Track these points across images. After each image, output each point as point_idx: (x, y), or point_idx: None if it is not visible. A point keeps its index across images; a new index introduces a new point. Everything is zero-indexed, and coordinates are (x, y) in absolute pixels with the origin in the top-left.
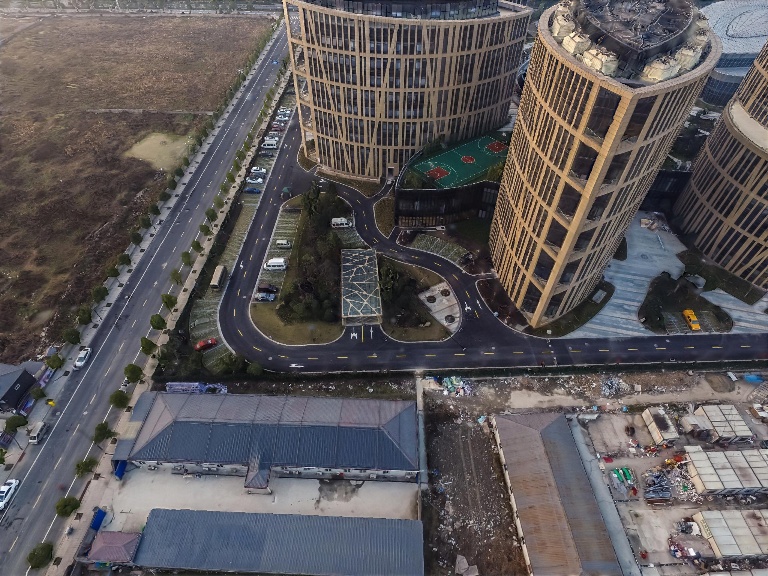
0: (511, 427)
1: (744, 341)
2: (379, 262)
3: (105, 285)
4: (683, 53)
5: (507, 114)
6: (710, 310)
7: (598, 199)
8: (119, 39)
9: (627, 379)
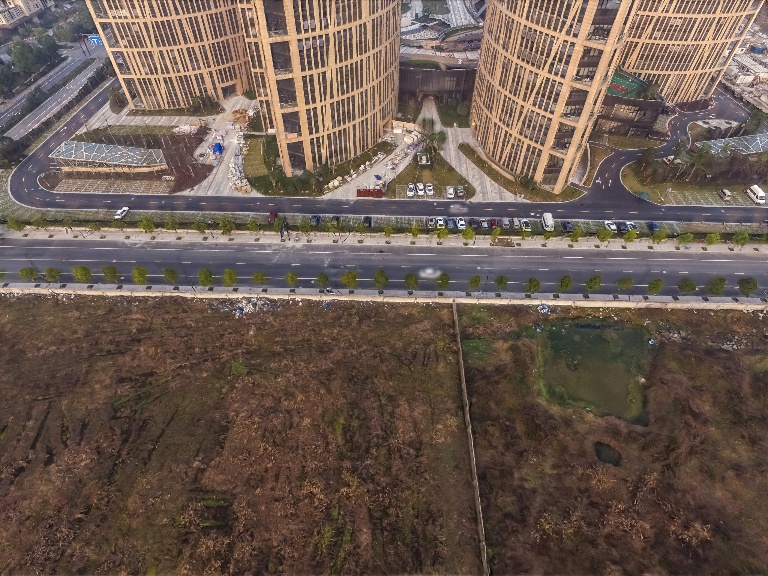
0: None
1: None
2: None
3: None
4: None
5: None
6: None
7: None
8: None
9: None
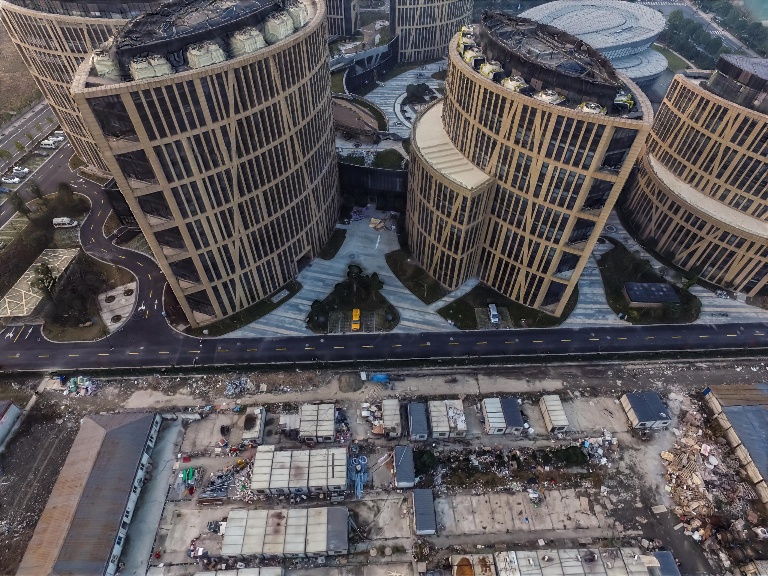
0: (89, 427)
1: (398, 340)
2: (78, 262)
3: None
4: (190, 52)
5: None
6: (384, 309)
7: (158, 199)
8: None
9: (254, 379)
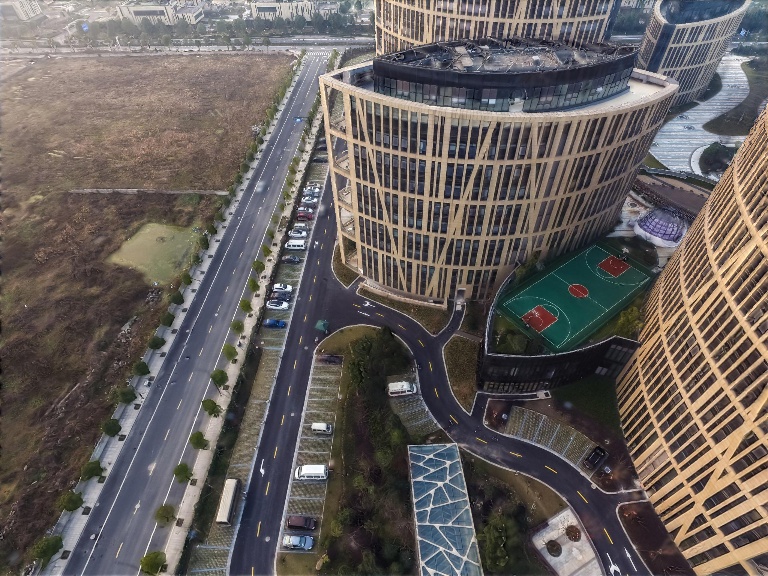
0: None
1: None
2: (465, 469)
3: (62, 517)
4: None
5: (619, 212)
6: None
7: None
8: (117, 86)
9: None
